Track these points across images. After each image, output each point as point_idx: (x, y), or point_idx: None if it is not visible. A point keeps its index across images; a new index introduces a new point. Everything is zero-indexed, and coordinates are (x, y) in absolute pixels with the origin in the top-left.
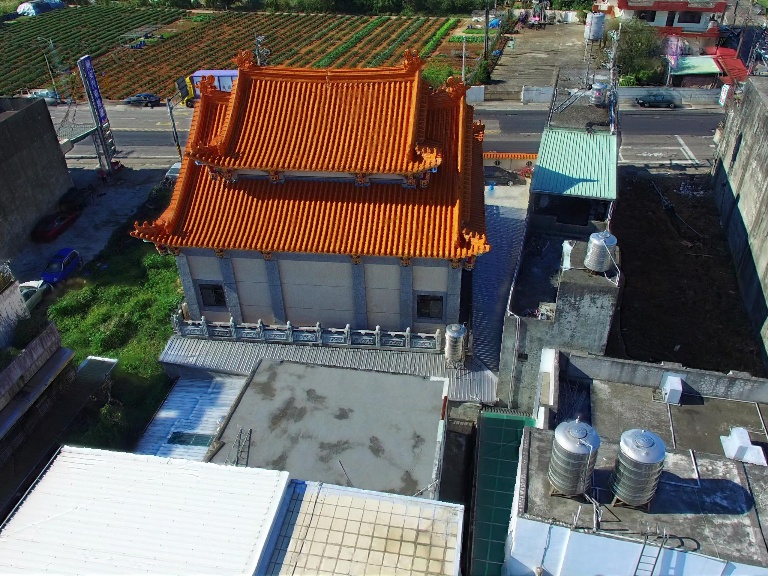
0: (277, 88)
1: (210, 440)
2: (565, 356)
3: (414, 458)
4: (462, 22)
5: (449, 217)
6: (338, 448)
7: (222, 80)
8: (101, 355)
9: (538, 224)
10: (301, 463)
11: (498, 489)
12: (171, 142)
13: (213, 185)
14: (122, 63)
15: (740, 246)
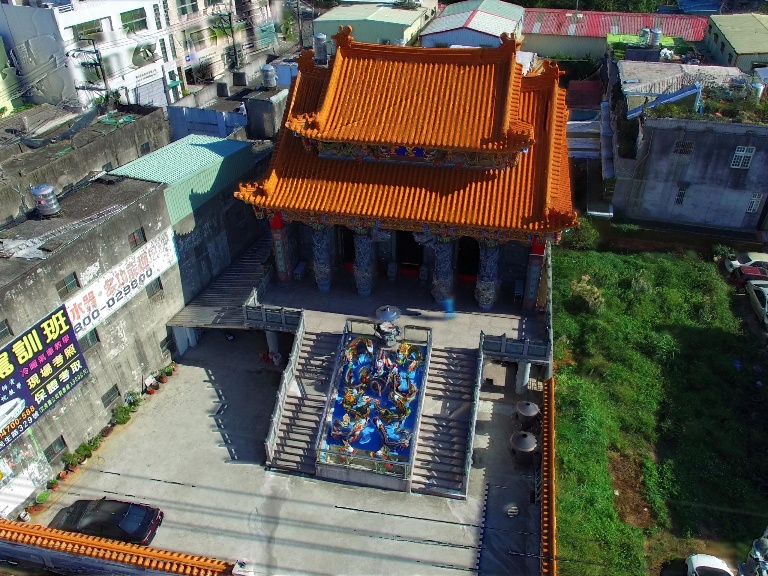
0: None
1: None
2: None
3: None
4: None
5: None
6: None
7: None
8: None
9: None
10: None
11: None
12: None
13: None
14: None
15: None
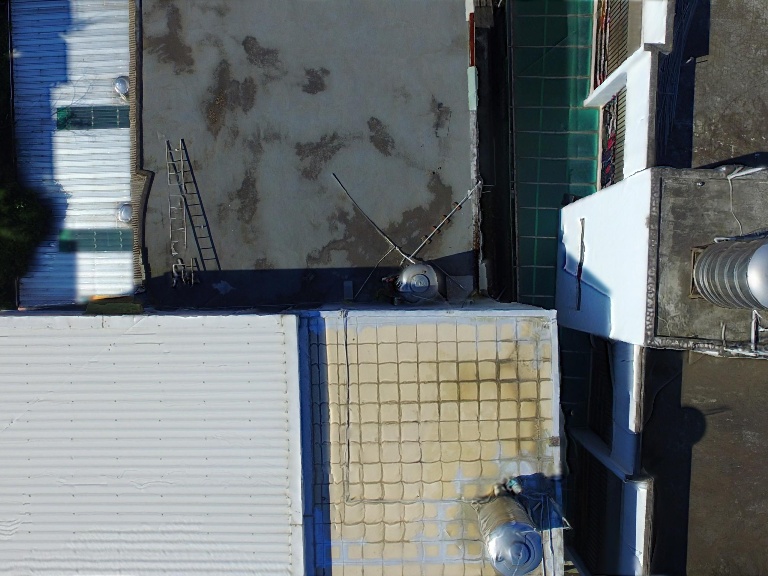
0: None
1: (118, 116)
2: None
3: (440, 148)
4: None
5: None
6: (325, 150)
7: None
8: None
9: None
10: (279, 188)
11: (543, 129)
12: None
13: None
14: None
15: None
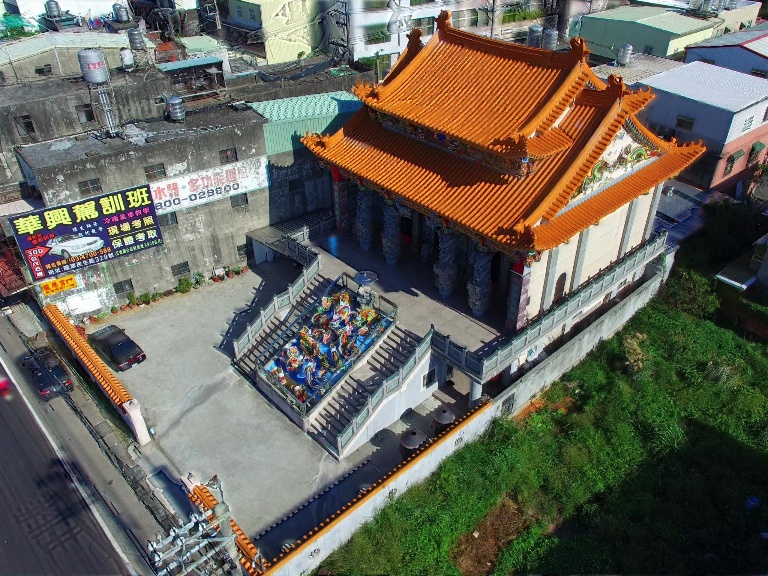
0: None
1: None
2: None
3: None
4: None
5: None
6: None
7: None
8: None
9: None
10: None
11: None
12: None
13: None
14: None
15: None
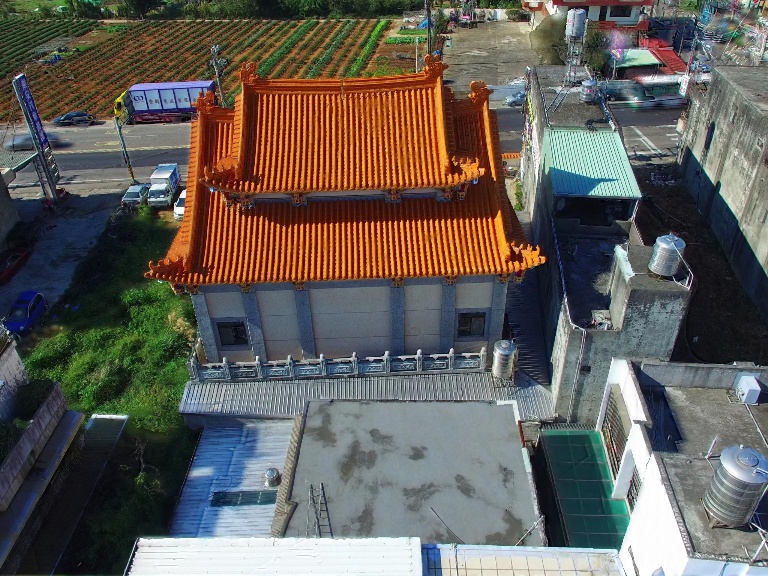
0: (287, 102)
1: (260, 497)
2: (636, 366)
3: (509, 494)
4: (393, 23)
5: (492, 229)
6: (424, 493)
7: (163, 94)
8: (95, 410)
9: (561, 228)
10: (390, 516)
11: (585, 513)
12: (117, 163)
13: (227, 213)
14: (39, 80)
15: (729, 232)
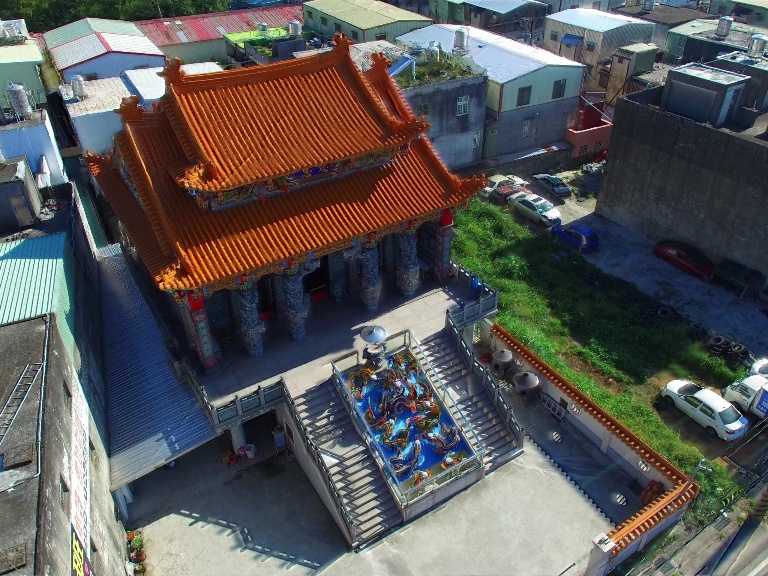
0: None
1: None
2: None
3: None
4: None
5: None
6: None
7: None
8: None
9: None
10: None
11: None
12: None
13: None
14: None
15: None
